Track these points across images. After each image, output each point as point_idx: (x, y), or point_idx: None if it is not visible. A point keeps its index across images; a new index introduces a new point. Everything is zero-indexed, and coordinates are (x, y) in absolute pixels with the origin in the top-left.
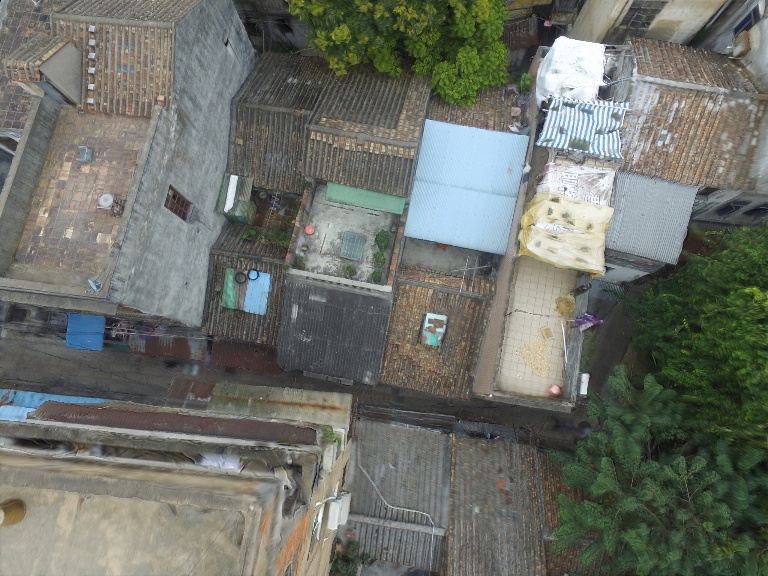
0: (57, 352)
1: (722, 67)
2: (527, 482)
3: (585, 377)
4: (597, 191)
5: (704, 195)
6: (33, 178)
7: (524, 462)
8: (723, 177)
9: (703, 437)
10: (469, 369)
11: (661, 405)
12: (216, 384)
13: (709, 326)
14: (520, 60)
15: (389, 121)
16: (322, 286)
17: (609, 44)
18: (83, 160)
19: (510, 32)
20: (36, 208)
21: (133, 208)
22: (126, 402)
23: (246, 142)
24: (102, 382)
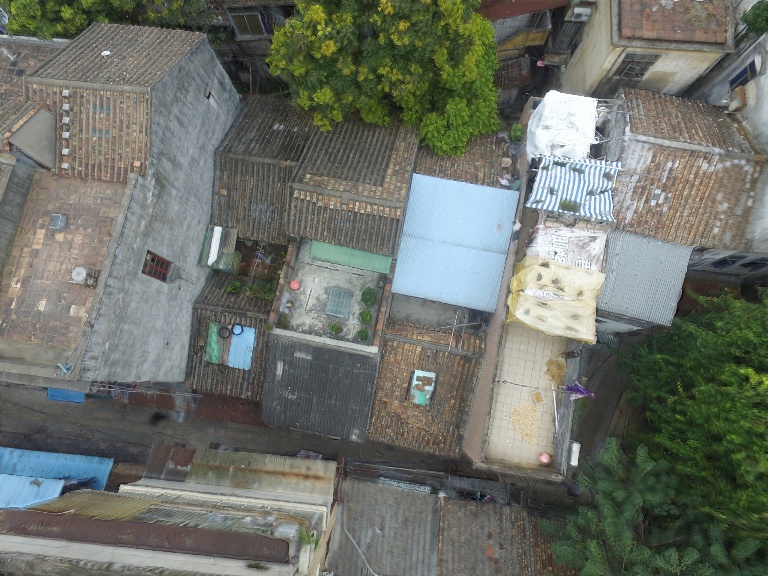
0: (41, 398)
1: (717, 122)
2: (517, 549)
3: (576, 447)
4: (588, 255)
5: (699, 251)
6: (5, 247)
7: (514, 526)
8: (718, 237)
9: (697, 513)
10: (458, 427)
11: (654, 479)
12: (197, 450)
13: (703, 398)
14: (513, 98)
15: (375, 177)
16: (307, 343)
17: (602, 93)
18: (57, 228)
19: (502, 72)
20: (8, 278)
21: (106, 283)
22: (97, 491)
23: (230, 193)
24: (86, 429)
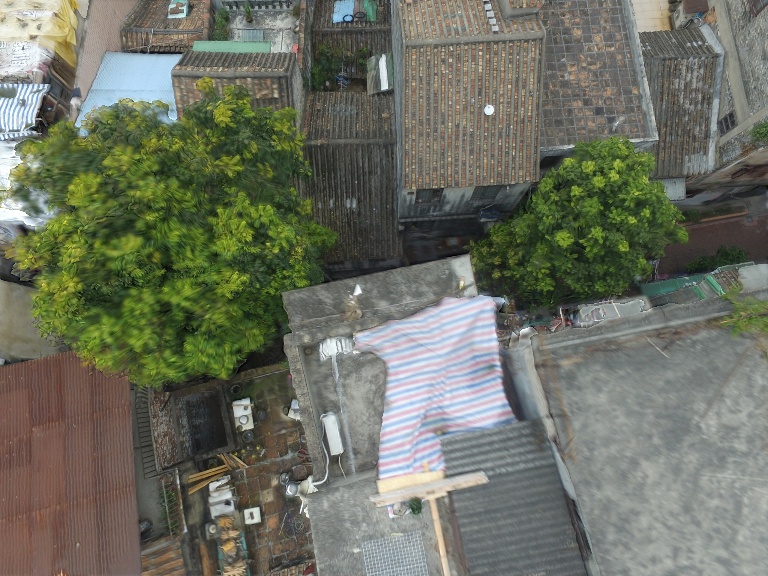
0: None
1: None
2: None
3: None
4: None
5: None
6: None
7: None
8: None
9: None
10: None
11: None
12: None
13: None
14: None
15: None
16: None
17: None
18: None
19: None
20: None
21: None
22: None
23: (379, 117)
24: None
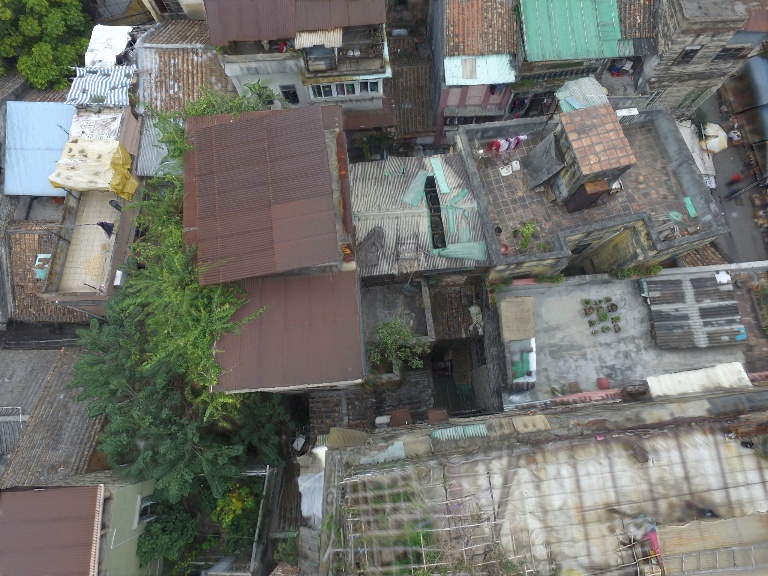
0: None
1: None
2: None
3: (118, 272)
4: (108, 131)
5: None
6: None
7: None
8: None
9: None
10: None
11: None
12: None
13: None
14: None
15: None
16: None
17: None
18: None
19: None
20: None
21: None
22: None
23: None
24: None
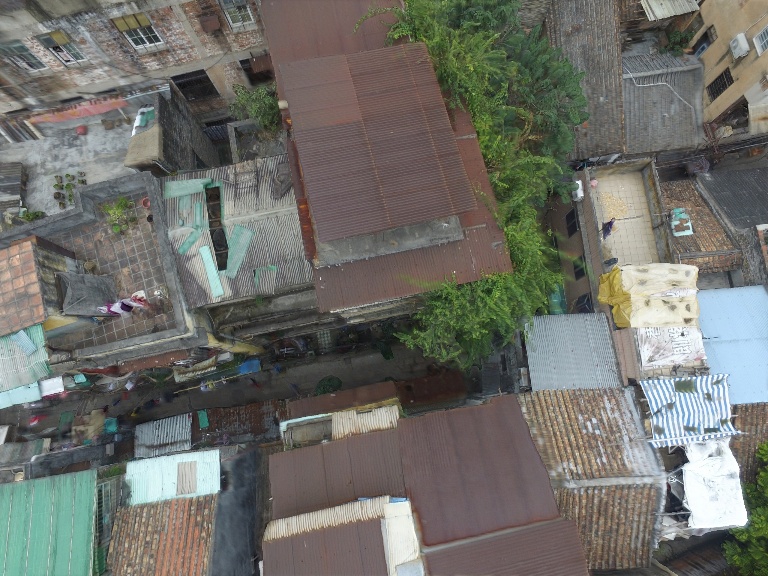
0: None
1: None
2: None
3: (581, 194)
4: (651, 342)
5: None
6: None
7: None
8: None
9: None
10: None
11: None
12: None
13: None
14: None
15: None
16: None
17: None
18: None
19: None
20: None
21: None
22: None
23: None
24: None
